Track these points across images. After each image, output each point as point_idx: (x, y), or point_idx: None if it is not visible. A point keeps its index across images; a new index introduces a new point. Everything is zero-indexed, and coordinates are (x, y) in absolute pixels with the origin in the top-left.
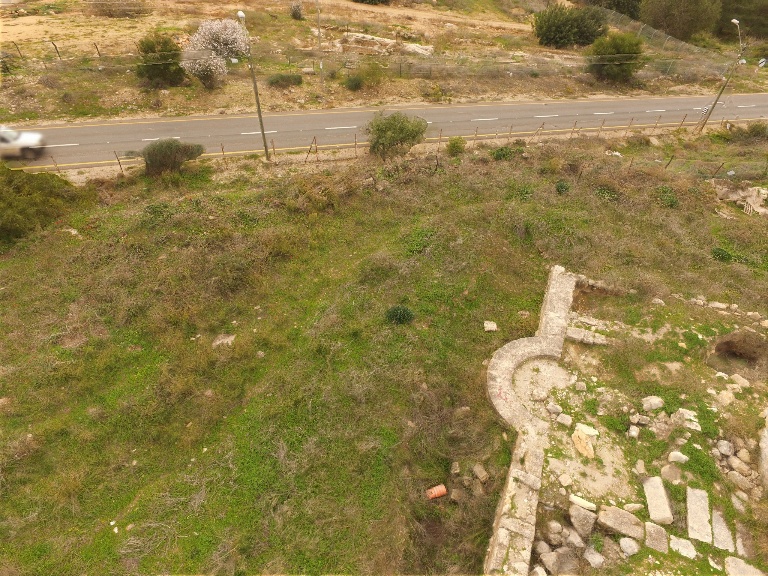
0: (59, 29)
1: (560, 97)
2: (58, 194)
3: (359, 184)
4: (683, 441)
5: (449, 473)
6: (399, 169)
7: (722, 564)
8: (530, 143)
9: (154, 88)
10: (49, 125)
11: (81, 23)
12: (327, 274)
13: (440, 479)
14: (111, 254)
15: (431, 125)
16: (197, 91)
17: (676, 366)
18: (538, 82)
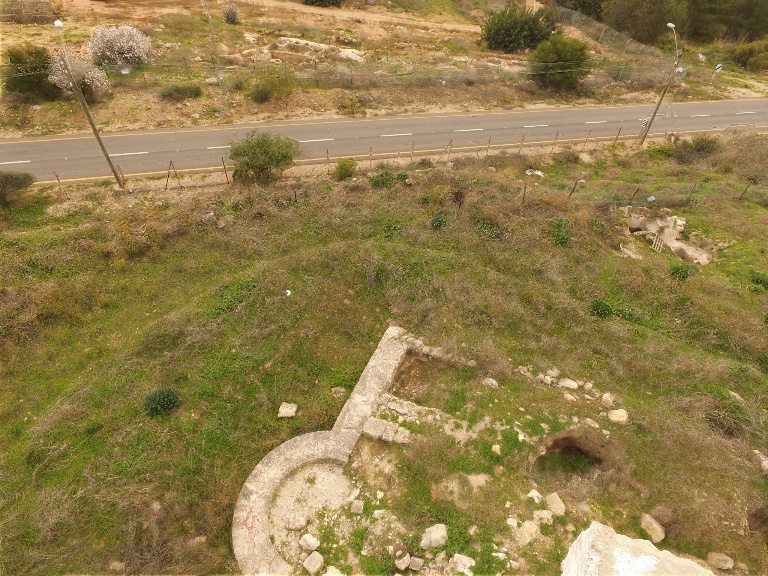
0: None
1: (495, 107)
2: None
3: (194, 221)
4: None
5: None
6: (254, 200)
7: None
8: (439, 162)
9: (24, 103)
10: None
11: None
12: (105, 341)
13: None
14: None
15: (331, 142)
16: (75, 106)
17: (480, 480)
18: (473, 91)
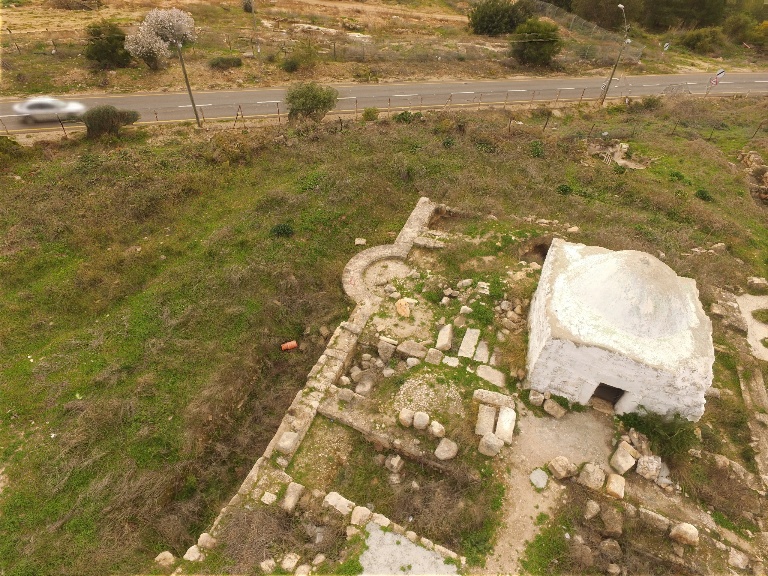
0: (17, 20)
1: (482, 78)
2: (6, 151)
3: (271, 140)
4: (473, 301)
5: (302, 334)
6: (309, 130)
7: (475, 369)
8: None
9: (102, 69)
10: (3, 100)
11: (39, 14)
12: (230, 206)
13: (293, 337)
14: (48, 192)
15: None
16: (143, 72)
17: (490, 258)
18: (464, 65)
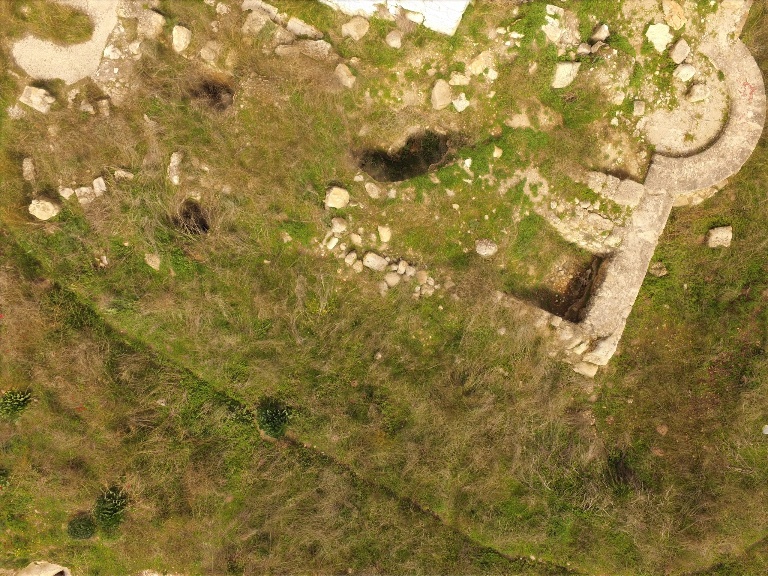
0: None
1: None
2: None
3: None
4: None
5: None
6: None
7: None
8: None
9: None
10: None
11: None
12: None
13: None
14: None
15: None
16: None
17: (518, 119)
18: None
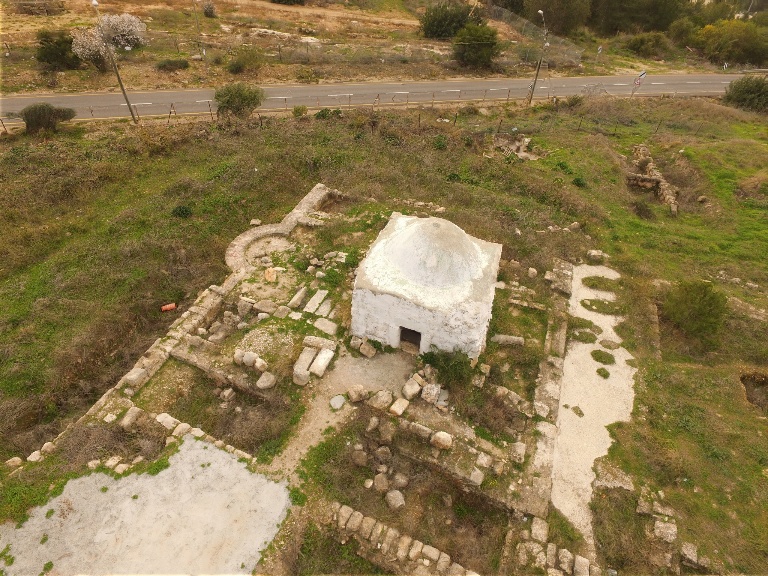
0: None
1: (422, 79)
2: None
3: (192, 134)
4: (329, 267)
5: (182, 298)
6: (232, 125)
7: (314, 321)
8: None
9: (52, 70)
10: None
11: (1, 19)
12: (142, 191)
13: (173, 300)
14: None
15: None
16: (91, 73)
17: (358, 234)
18: (406, 67)
